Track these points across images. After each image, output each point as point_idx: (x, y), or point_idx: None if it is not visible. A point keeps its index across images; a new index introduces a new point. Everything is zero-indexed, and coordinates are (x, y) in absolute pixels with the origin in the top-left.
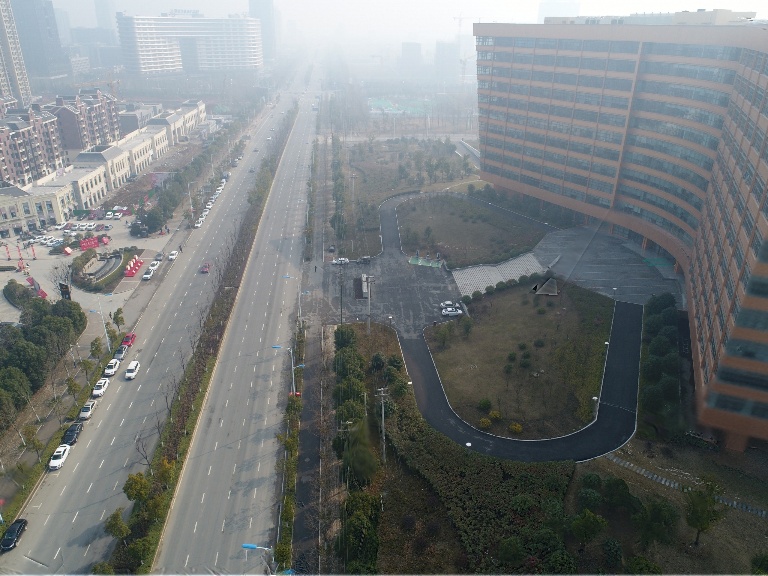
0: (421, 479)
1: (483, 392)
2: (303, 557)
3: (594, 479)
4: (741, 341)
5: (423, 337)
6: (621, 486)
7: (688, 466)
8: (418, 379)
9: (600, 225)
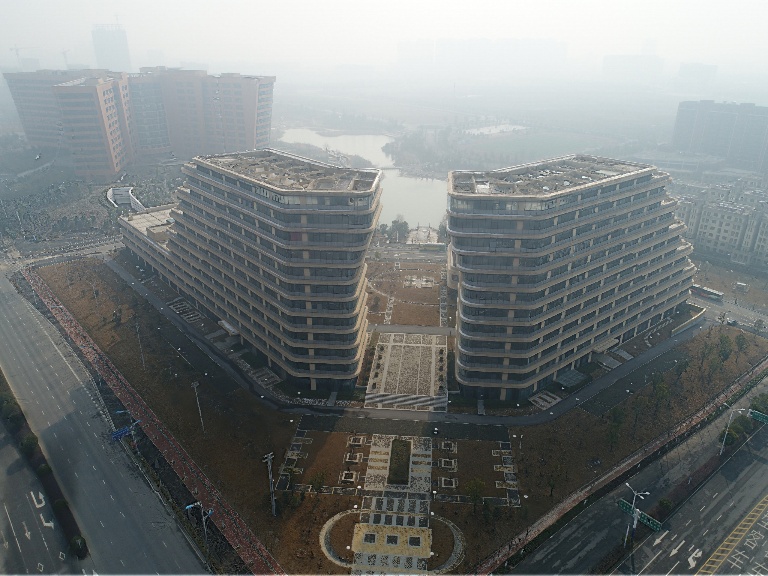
0: (4, 200)
1: (23, 187)
2: None
3: (47, 187)
4: (72, 152)
5: (3, 184)
6: (52, 186)
7: None
8: (1, 189)
9: (52, 140)
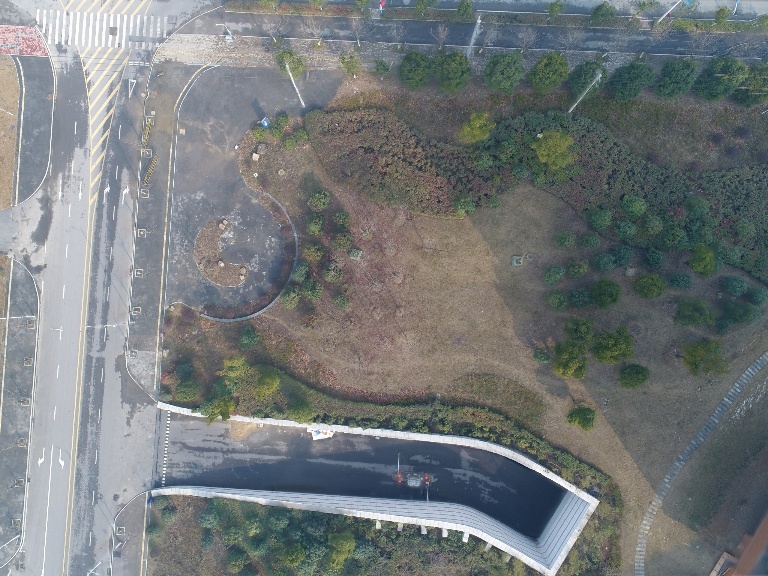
0: None
1: None
2: (720, 41)
3: (758, 296)
4: None
5: None
6: (742, 311)
7: (767, 406)
8: None
9: None
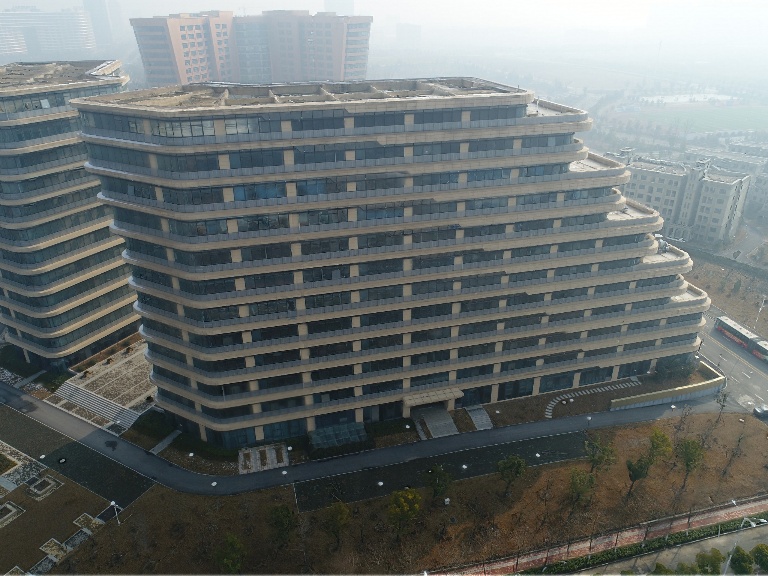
0: None
1: None
2: None
3: None
4: None
5: None
6: None
7: None
8: None
9: None
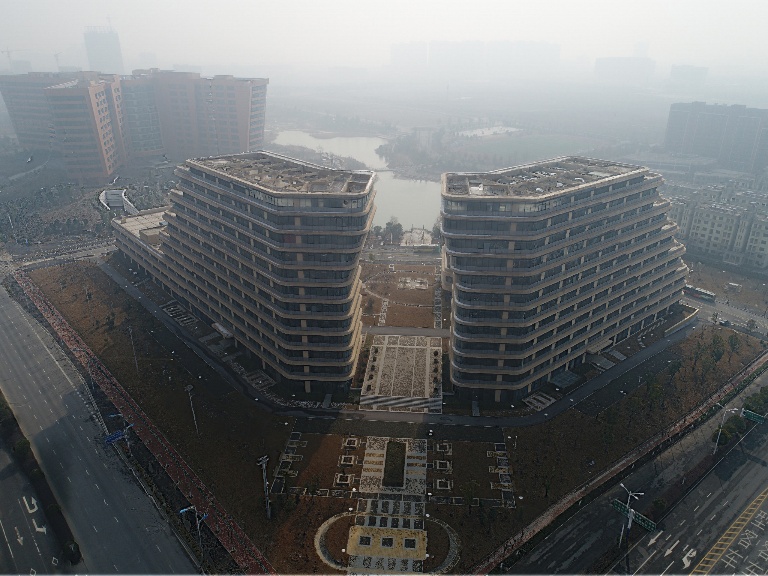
0: None
1: None
2: None
3: (39, 190)
4: (65, 154)
5: None
6: None
7: None
8: None
9: (44, 142)
